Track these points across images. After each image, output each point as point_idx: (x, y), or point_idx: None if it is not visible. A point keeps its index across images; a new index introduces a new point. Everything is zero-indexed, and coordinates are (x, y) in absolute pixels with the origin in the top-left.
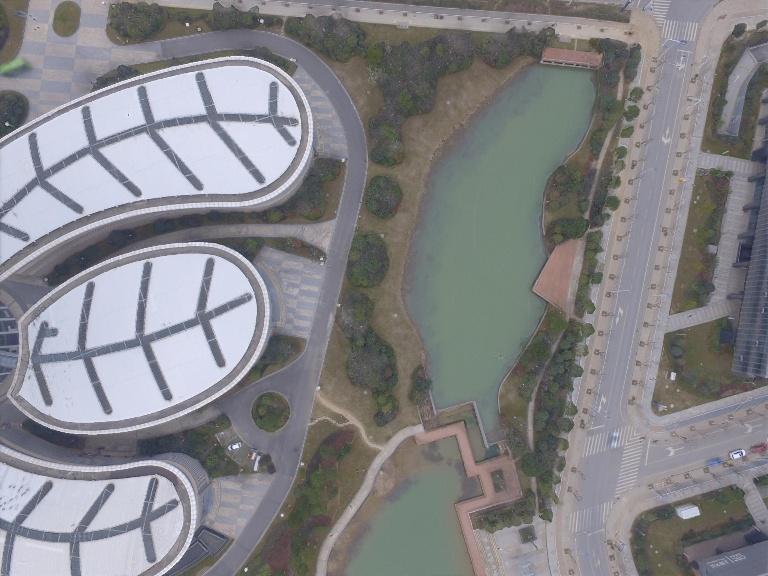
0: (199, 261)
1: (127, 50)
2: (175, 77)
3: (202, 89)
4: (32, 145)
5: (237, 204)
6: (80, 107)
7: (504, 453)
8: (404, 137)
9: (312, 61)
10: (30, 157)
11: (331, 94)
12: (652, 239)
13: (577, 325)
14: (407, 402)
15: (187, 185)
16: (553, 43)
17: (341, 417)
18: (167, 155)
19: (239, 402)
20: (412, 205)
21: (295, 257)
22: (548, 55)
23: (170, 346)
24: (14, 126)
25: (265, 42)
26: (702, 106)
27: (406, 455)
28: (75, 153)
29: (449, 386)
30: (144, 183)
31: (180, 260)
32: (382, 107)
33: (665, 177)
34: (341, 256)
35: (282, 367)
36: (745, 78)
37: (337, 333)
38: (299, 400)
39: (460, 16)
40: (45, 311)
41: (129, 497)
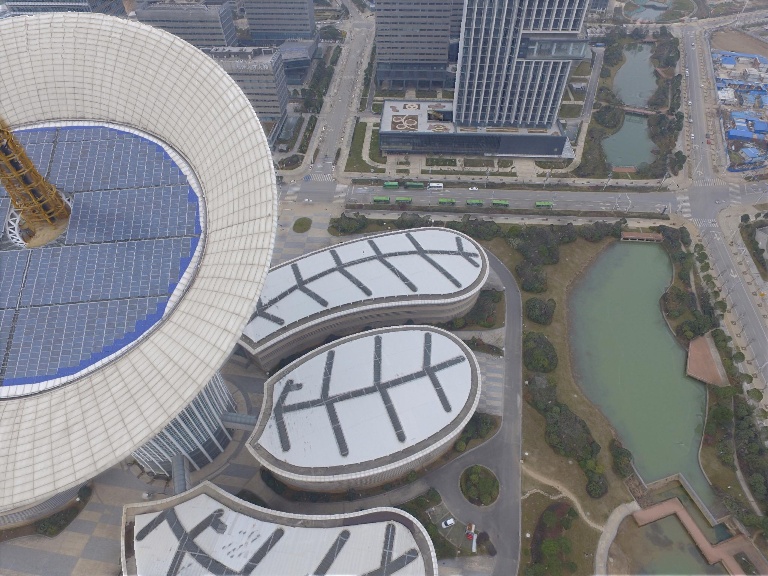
0: (419, 334)
1: (341, 238)
2: (391, 236)
3: (411, 239)
4: (294, 269)
5: (442, 301)
6: (328, 250)
7: (736, 533)
8: None
9: None
10: (293, 274)
11: None
12: (765, 335)
13: (742, 399)
14: (613, 476)
15: (405, 288)
16: (625, 229)
17: (553, 488)
18: (392, 270)
19: (446, 476)
20: (562, 318)
21: (478, 353)
22: (625, 235)
23: (404, 392)
24: None
25: None
26: (747, 257)
27: (631, 539)
28: (327, 270)
29: (648, 459)
30: (375, 287)
31: (404, 334)
32: (522, 261)
33: (748, 297)
34: (516, 352)
35: (483, 441)
36: (766, 243)
37: (528, 410)
38: (506, 473)
39: (558, 219)
40: (291, 373)
41: (366, 544)
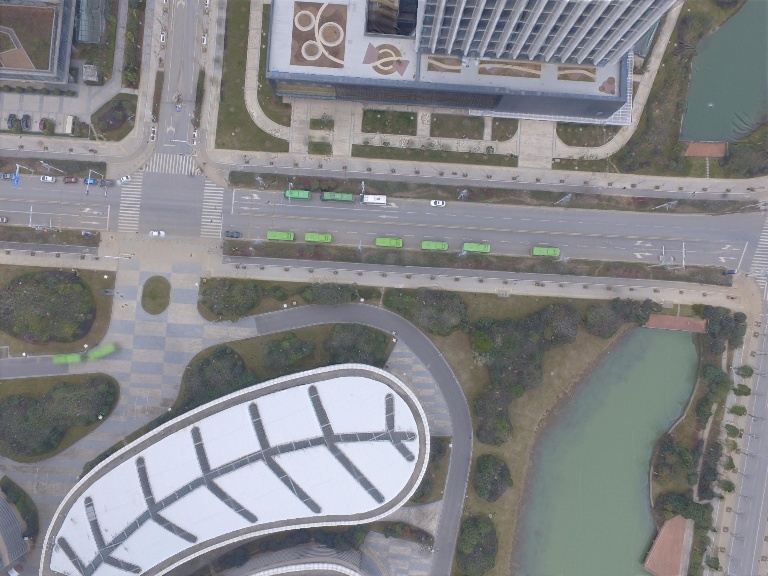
0: None
1: (220, 326)
2: (287, 392)
3: (317, 407)
4: (141, 473)
5: (355, 523)
6: (189, 428)
7: None
8: (510, 413)
9: (412, 334)
10: (140, 487)
11: (433, 368)
12: (761, 509)
13: None
14: None
15: (304, 509)
16: None
17: None
18: (284, 482)
19: None
20: (518, 480)
21: (402, 541)
22: (652, 323)
23: None
24: (105, 414)
25: (363, 314)
26: None
27: None
28: (188, 484)
29: None
30: (260, 510)
31: None
32: (487, 384)
33: None
34: (449, 539)
35: None
36: None
37: None
38: None
39: (561, 283)
40: None
41: None
